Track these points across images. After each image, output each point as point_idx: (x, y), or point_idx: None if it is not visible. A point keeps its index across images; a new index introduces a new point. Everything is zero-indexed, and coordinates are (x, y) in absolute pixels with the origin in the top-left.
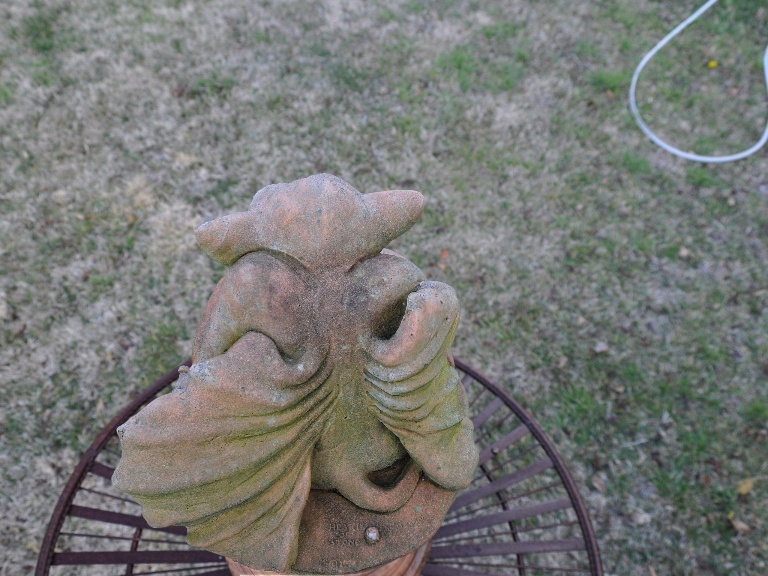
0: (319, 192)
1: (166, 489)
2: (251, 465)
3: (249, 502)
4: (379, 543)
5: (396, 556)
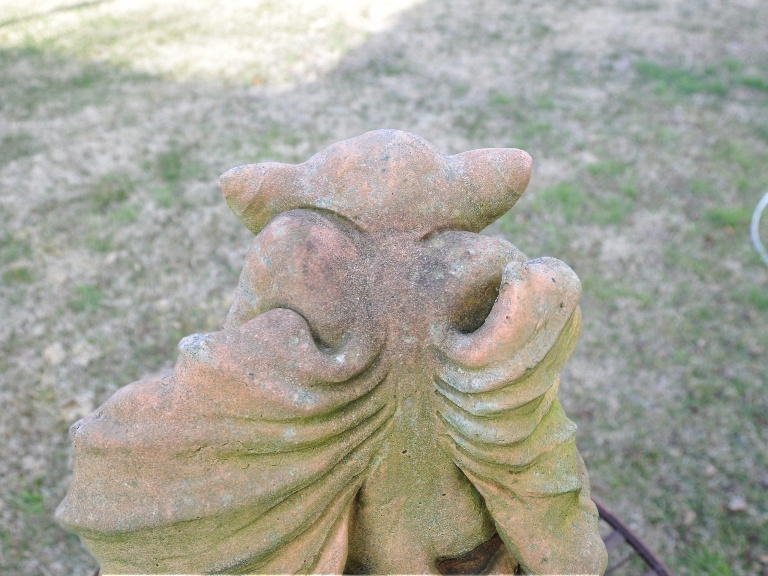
0: (387, 140)
1: (124, 523)
2: (253, 500)
3: (250, 569)
4: None
5: None
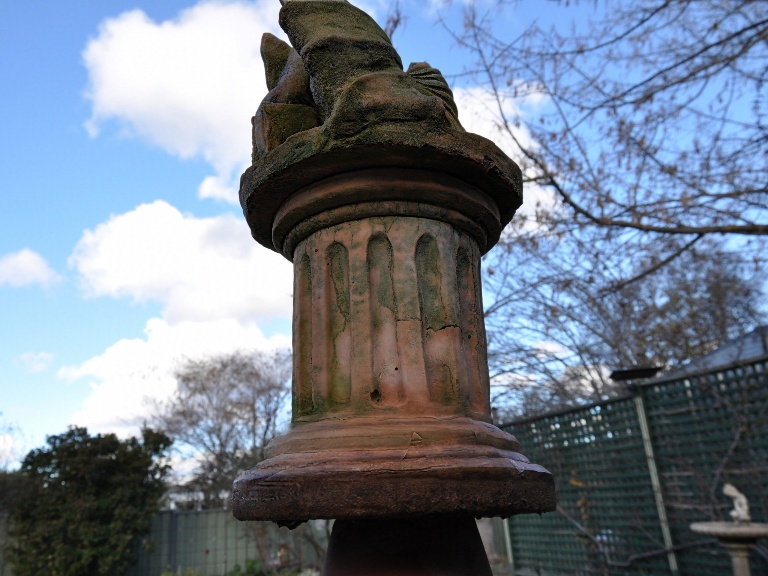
0: None
1: None
2: None
3: (389, 63)
4: None
5: None
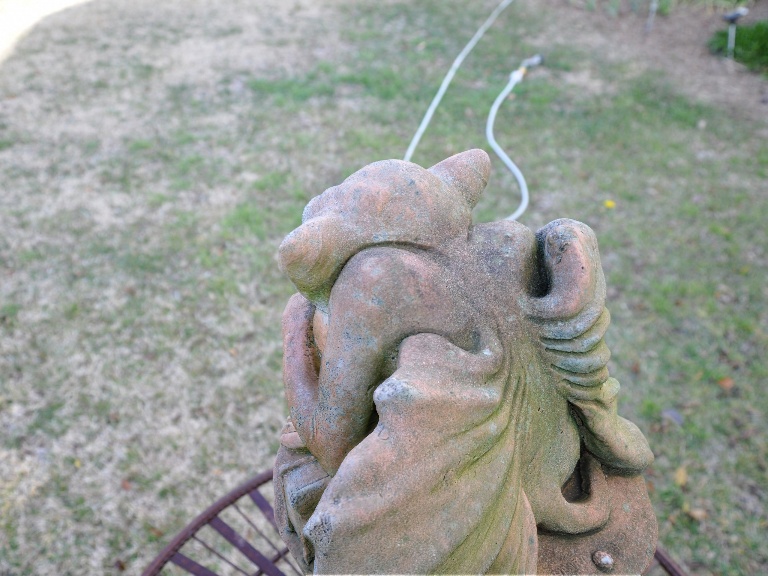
0: (396, 169)
1: None
2: (493, 498)
3: None
4: (616, 566)
5: (642, 571)
